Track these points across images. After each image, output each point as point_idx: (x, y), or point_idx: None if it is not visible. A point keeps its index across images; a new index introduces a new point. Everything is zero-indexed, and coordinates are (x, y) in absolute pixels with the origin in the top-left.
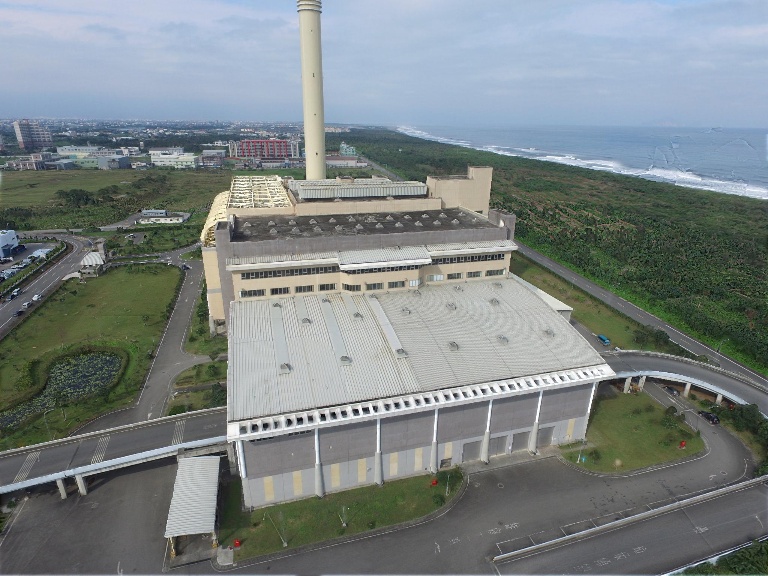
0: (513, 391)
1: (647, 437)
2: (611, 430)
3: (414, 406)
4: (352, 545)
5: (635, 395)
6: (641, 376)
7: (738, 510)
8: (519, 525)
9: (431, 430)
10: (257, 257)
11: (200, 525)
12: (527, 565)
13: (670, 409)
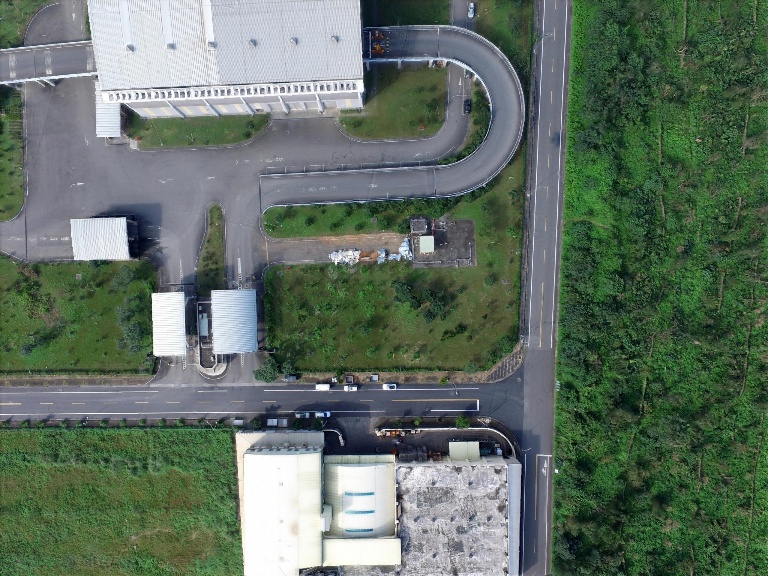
0: (281, 94)
1: (405, 116)
2: (386, 104)
3: (212, 96)
4: (195, 152)
5: (436, 71)
6: (441, 60)
7: (402, 181)
8: (284, 160)
9: None
10: None
11: (113, 133)
12: (275, 182)
13: None
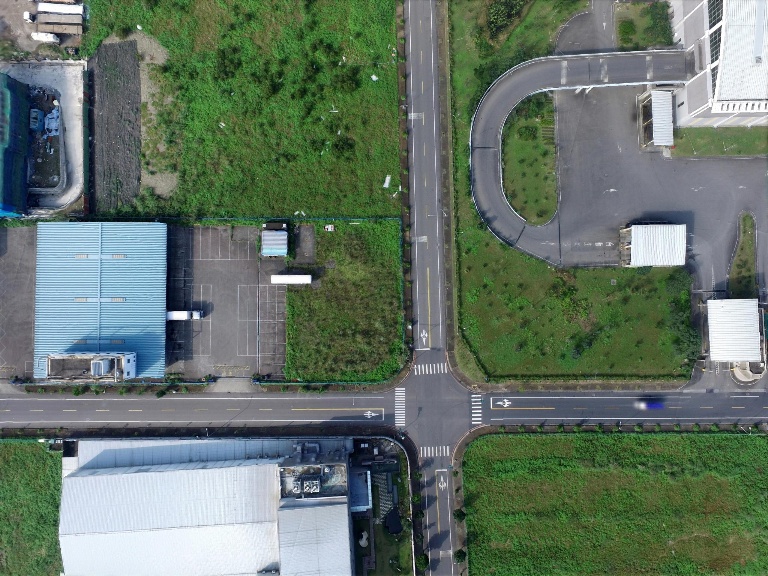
0: None
1: None
2: None
3: None
4: (727, 161)
5: None
6: None
7: None
8: None
9: None
10: None
11: (668, 141)
12: None
13: None
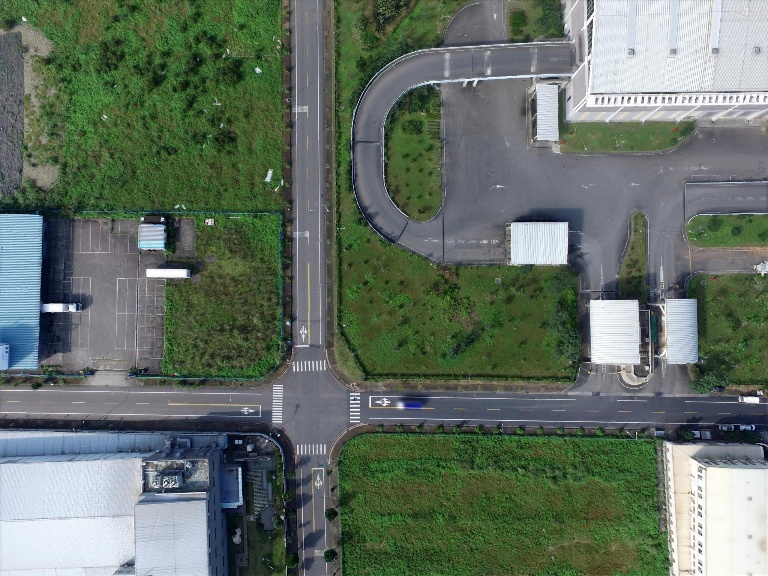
0: None
1: None
2: None
3: (700, 103)
4: (619, 158)
5: None
6: None
7: None
8: (709, 168)
9: (697, 106)
10: None
11: (553, 136)
12: (701, 190)
13: None
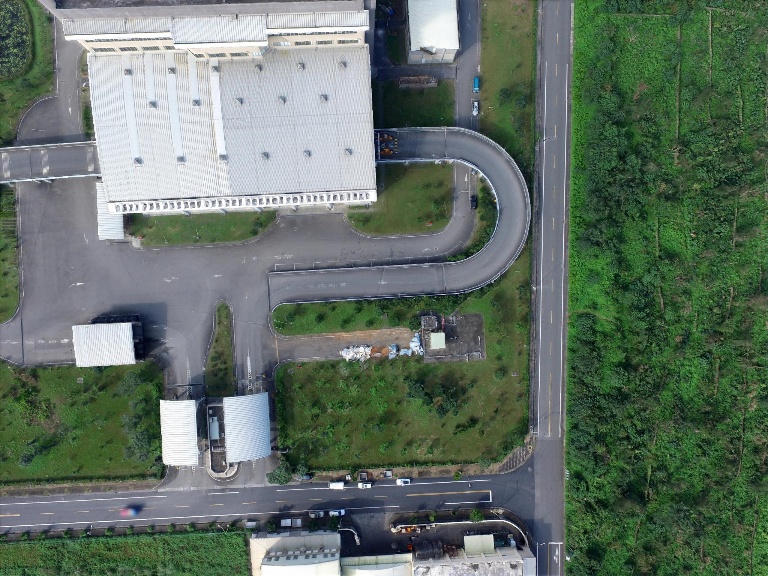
0: (294, 204)
1: (413, 211)
2: (394, 200)
3: (224, 207)
4: (201, 250)
5: (442, 167)
6: None
7: (412, 277)
8: (292, 257)
9: None
10: (91, 21)
11: (116, 235)
12: (284, 279)
13: (440, 199)
